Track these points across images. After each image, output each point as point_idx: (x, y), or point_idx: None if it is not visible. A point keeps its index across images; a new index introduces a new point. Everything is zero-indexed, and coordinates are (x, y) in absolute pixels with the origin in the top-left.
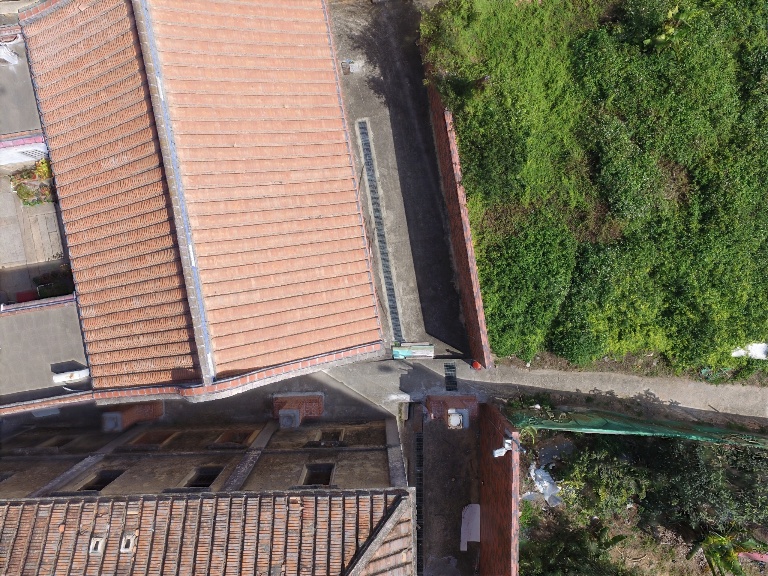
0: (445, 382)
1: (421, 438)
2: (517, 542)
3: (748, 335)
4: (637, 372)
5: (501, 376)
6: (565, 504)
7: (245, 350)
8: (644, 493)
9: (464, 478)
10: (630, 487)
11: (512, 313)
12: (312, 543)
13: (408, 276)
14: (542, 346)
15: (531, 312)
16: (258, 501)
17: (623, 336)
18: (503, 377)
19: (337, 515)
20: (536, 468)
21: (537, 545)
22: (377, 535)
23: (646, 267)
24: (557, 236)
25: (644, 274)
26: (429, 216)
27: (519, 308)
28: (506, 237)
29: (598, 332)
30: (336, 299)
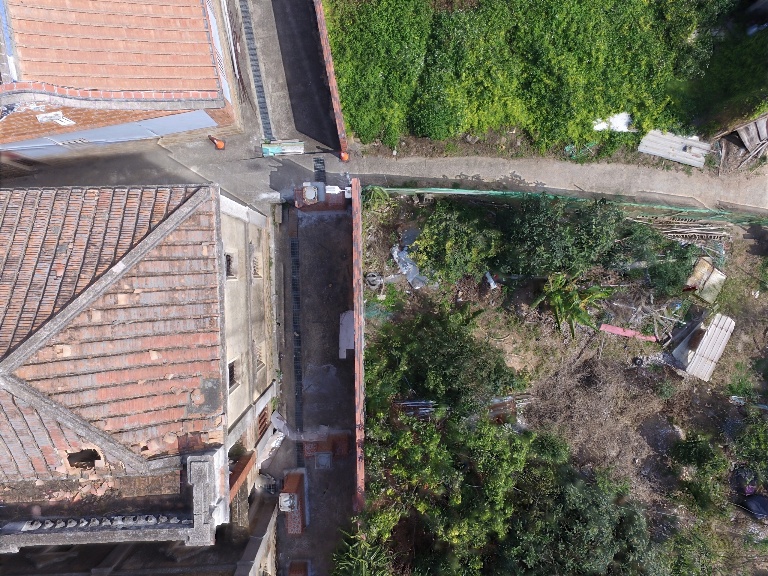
0: (315, 177)
1: (297, 243)
2: (359, 292)
3: (606, 102)
4: (502, 154)
5: (369, 167)
6: (429, 286)
7: (57, 67)
8: (493, 250)
9: (341, 284)
10: (477, 241)
11: (367, 84)
12: (104, 227)
13: (277, 72)
14: (404, 127)
15: (388, 85)
16: (54, 194)
17: (481, 107)
18: (371, 168)
19: (133, 203)
20: (399, 250)
21: (401, 329)
22: (169, 216)
23: (500, 30)
24: (409, 1)
25: (499, 39)
26: (297, 10)
27: (375, 80)
28: (359, 5)
29: (454, 102)
30: (167, 40)
